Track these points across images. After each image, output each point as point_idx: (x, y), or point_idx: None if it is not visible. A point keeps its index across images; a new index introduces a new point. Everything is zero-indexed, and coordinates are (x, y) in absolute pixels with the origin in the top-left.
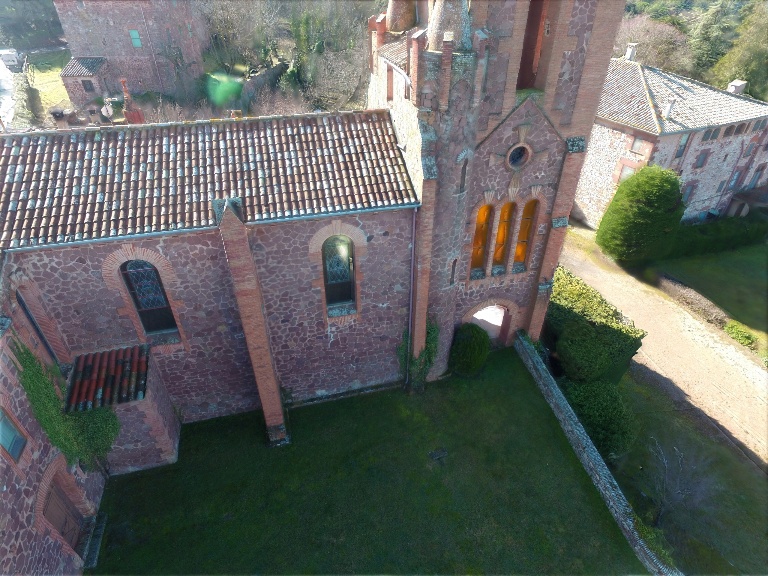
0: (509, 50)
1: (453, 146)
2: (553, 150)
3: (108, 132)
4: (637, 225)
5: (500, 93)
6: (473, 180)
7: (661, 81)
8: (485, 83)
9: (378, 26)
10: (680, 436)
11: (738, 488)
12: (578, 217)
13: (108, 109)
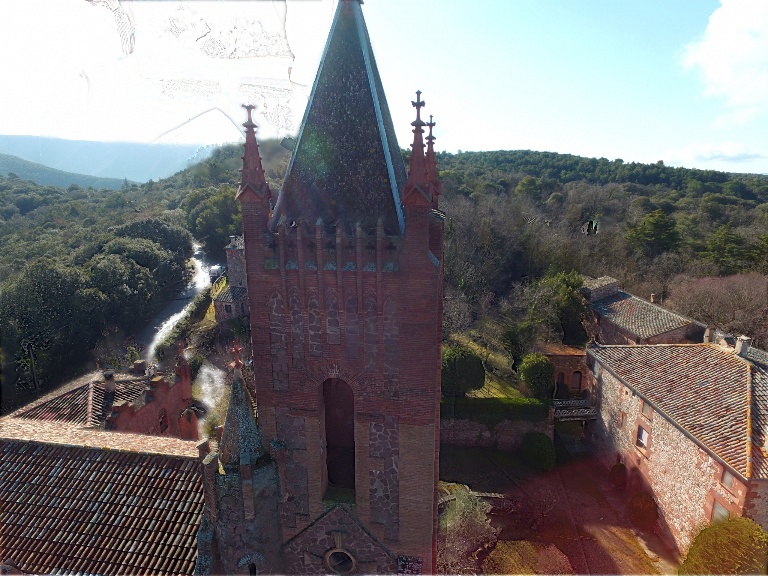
0: (306, 461)
1: (232, 550)
2: (383, 564)
3: (33, 445)
4: None
5: (305, 496)
6: (290, 573)
7: None
8: (278, 489)
9: None
10: None
11: None
12: (668, 545)
13: (150, 371)
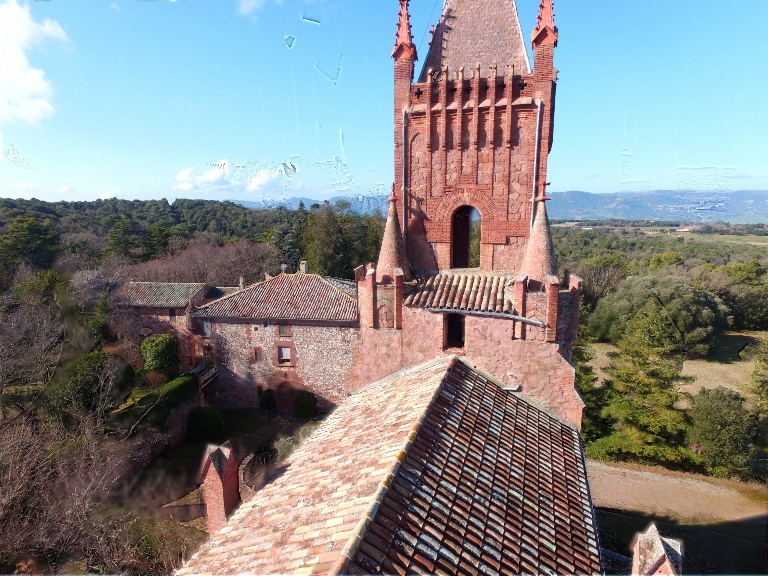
0: None
1: None
2: None
3: None
4: None
5: None
6: None
7: (341, 284)
8: None
9: (398, 279)
10: None
11: None
12: None
13: None
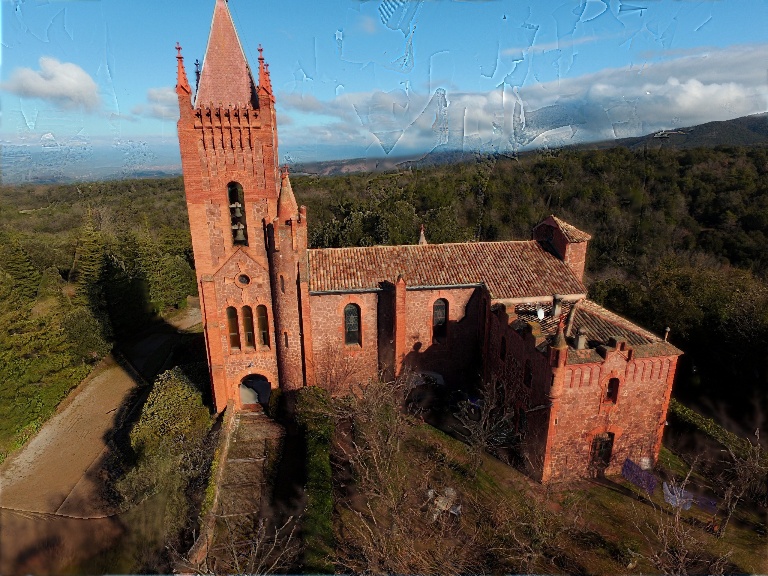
0: None
1: None
2: None
3: None
4: None
5: None
6: None
7: None
8: None
9: None
10: None
11: None
12: None
13: (539, 312)
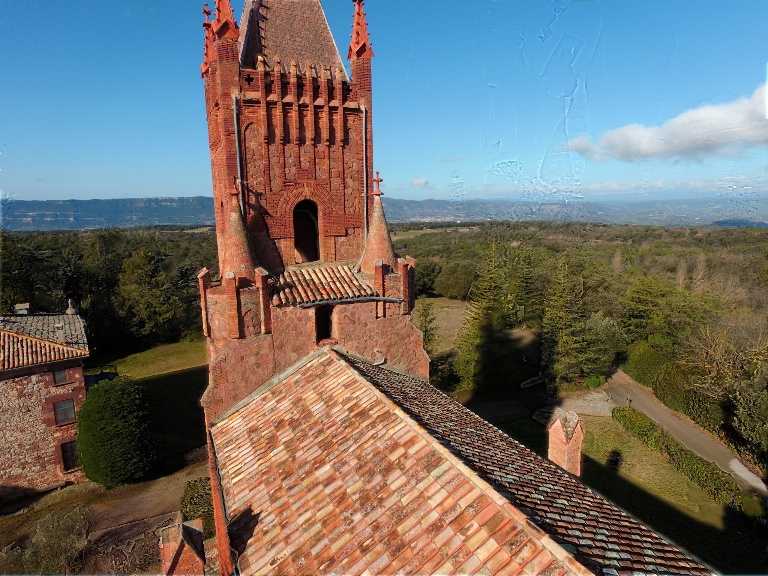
0: None
1: None
2: None
3: None
4: (143, 432)
5: None
6: None
7: None
8: None
9: (264, 279)
10: None
11: None
12: (17, 496)
13: None
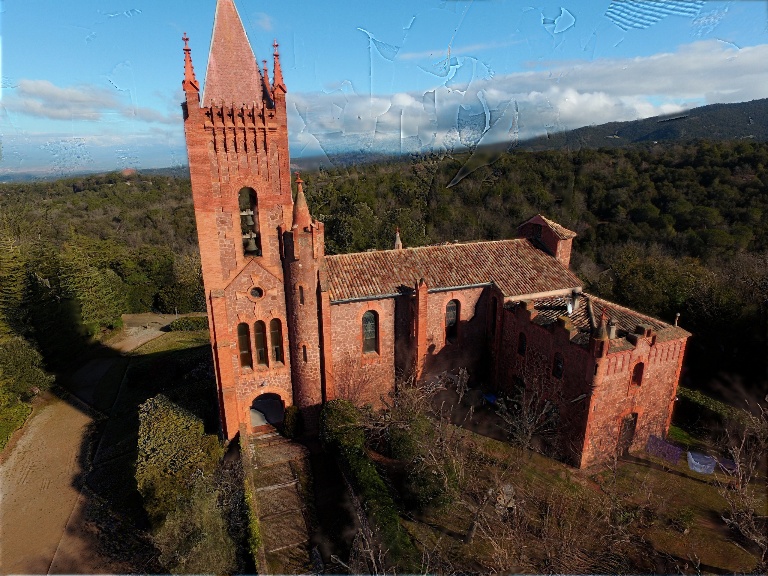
0: None
1: None
2: None
3: None
4: None
5: None
6: None
7: None
8: None
9: None
10: (136, 439)
11: (134, 422)
12: None
13: None
